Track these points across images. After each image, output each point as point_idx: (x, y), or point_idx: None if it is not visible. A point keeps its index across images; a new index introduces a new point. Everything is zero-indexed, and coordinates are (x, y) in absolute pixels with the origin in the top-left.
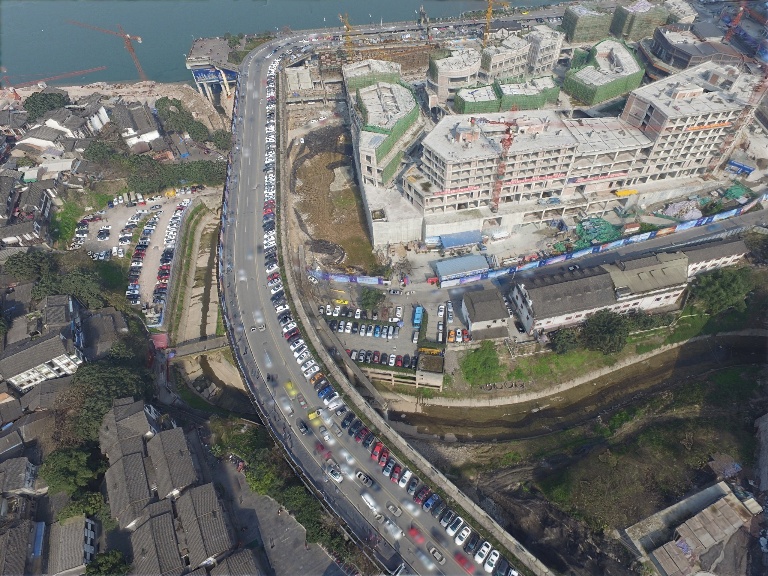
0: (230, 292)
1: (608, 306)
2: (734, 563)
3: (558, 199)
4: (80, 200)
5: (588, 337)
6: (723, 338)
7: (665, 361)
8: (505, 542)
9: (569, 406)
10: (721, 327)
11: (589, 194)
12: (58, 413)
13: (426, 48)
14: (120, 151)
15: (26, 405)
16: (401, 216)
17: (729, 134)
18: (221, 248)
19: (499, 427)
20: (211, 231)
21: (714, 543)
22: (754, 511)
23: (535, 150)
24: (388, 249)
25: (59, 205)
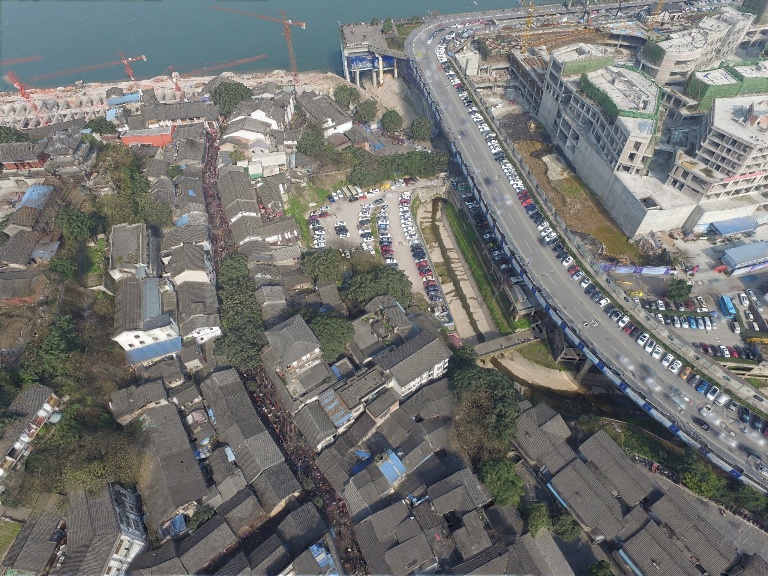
0: (539, 287)
1: None
2: None
3: None
4: (303, 195)
5: None
6: None
7: None
8: None
9: None
10: None
11: None
12: (454, 420)
13: (587, 32)
14: (325, 143)
15: (415, 413)
16: (674, 204)
17: None
18: None
19: None
20: (429, 225)
21: None
22: None
23: None
24: (654, 238)
25: (284, 201)
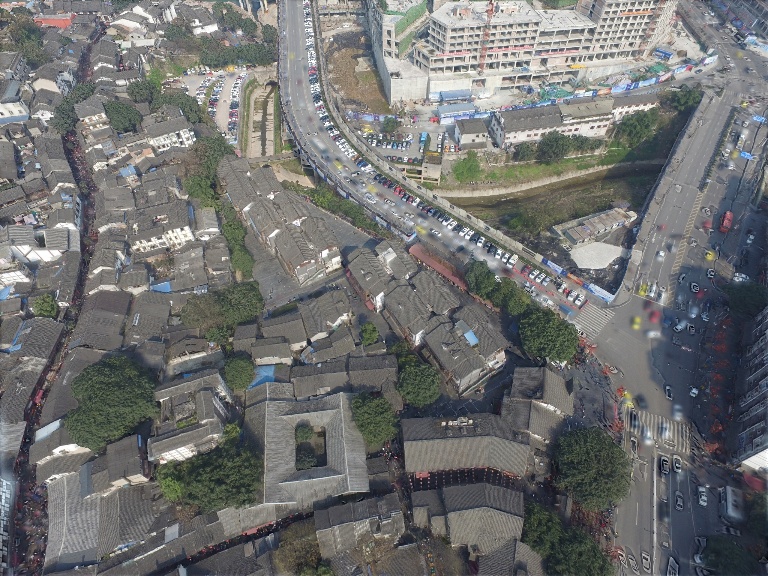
0: (290, 115)
1: (557, 128)
2: (616, 239)
3: (528, 68)
4: (163, 68)
5: (542, 149)
6: (640, 165)
7: (597, 176)
8: (478, 228)
9: (527, 198)
10: (638, 156)
11: (551, 67)
12: (186, 163)
13: None
14: (190, 36)
15: (163, 159)
16: (412, 76)
17: (652, 22)
18: (280, 90)
19: (478, 207)
20: (262, 100)
21: (605, 231)
22: (632, 216)
23: (510, 22)
24: (401, 103)
25: (147, 70)
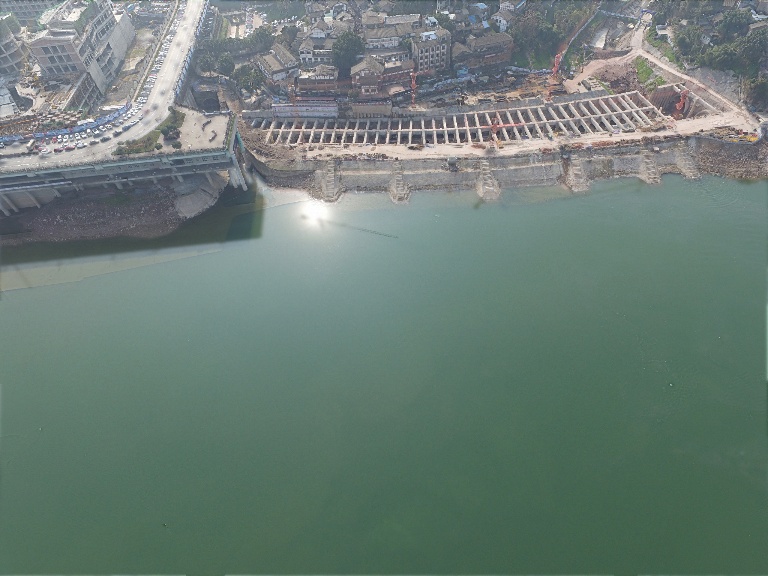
0: None
1: None
2: None
3: None
4: None
5: None
6: None
7: None
8: None
9: None
10: None
11: None
12: None
13: None
14: None
15: None
16: None
17: None
18: None
19: None
20: None
21: None
22: None
23: None
24: None
25: None
